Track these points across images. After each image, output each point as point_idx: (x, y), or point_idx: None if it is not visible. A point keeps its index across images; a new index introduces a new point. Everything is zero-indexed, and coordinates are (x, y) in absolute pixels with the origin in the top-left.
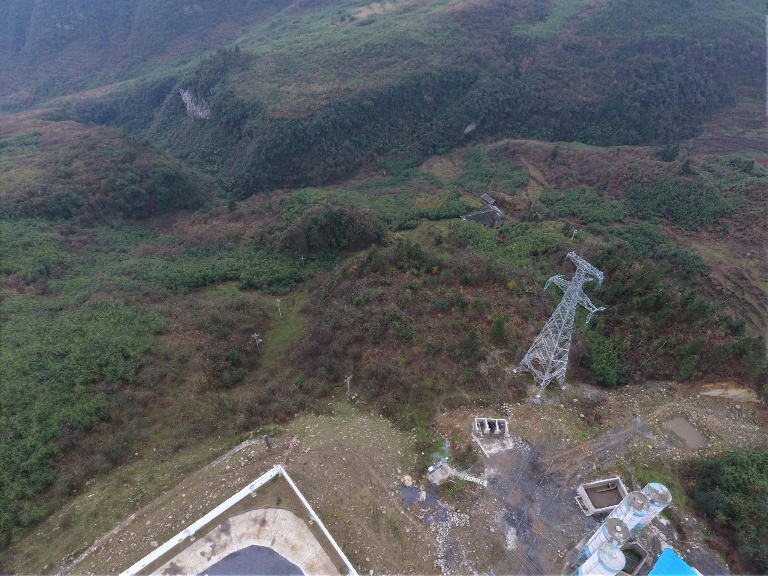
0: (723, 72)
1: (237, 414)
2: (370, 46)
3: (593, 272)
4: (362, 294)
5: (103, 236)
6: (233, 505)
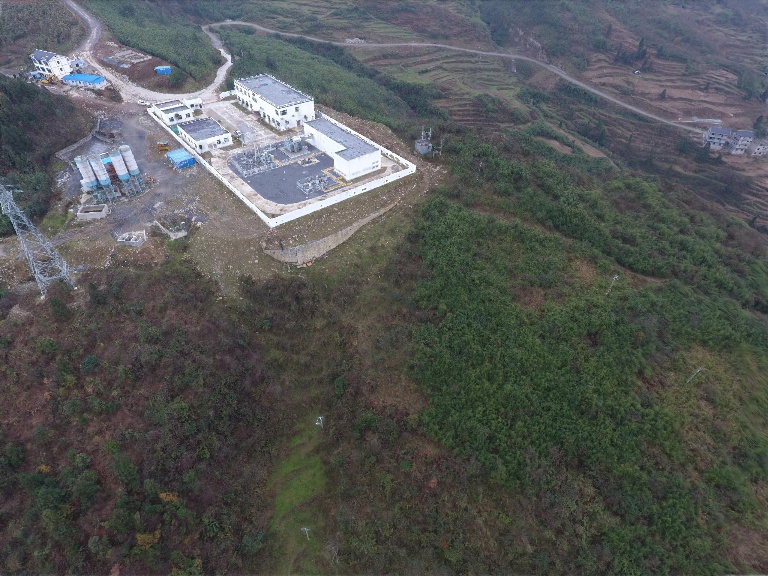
0: None
1: (320, 313)
2: None
3: None
4: (174, 406)
5: None
6: (297, 215)
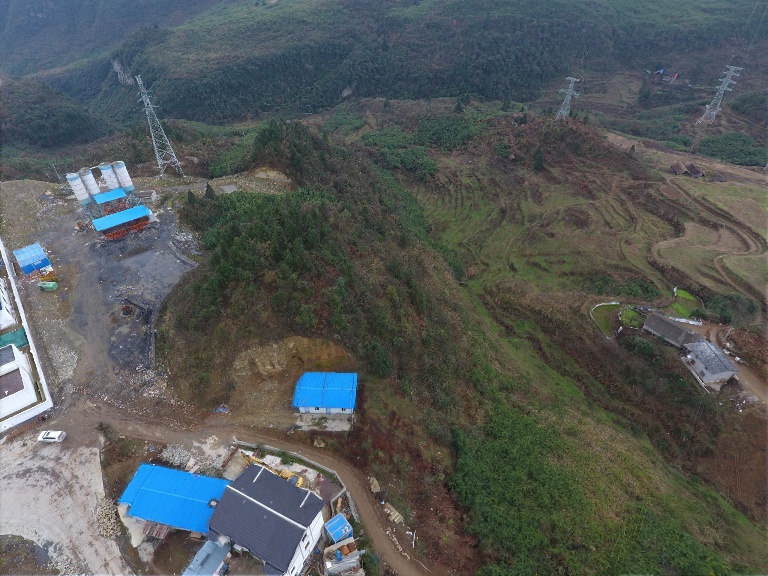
0: (557, 46)
1: None
2: (262, 23)
3: None
4: None
5: (6, 152)
6: None
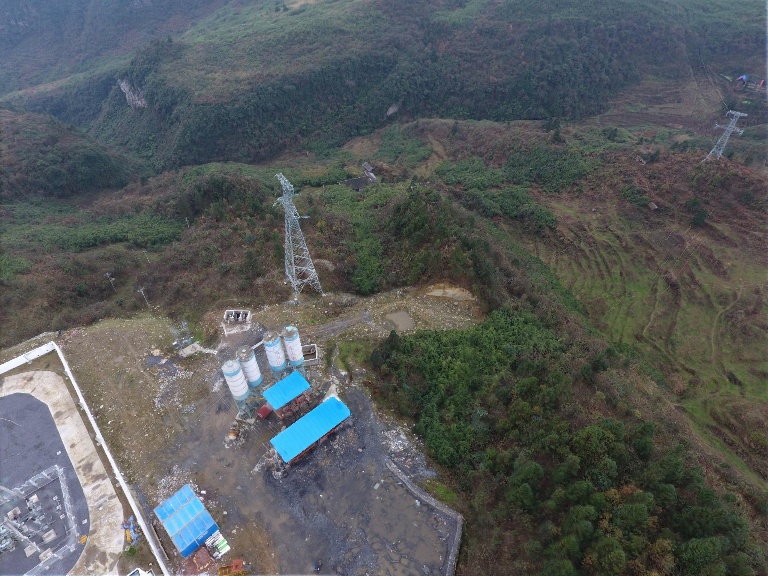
0: (626, 52)
1: None
2: (294, 34)
3: (286, 185)
4: (193, 235)
5: (20, 211)
6: (11, 369)
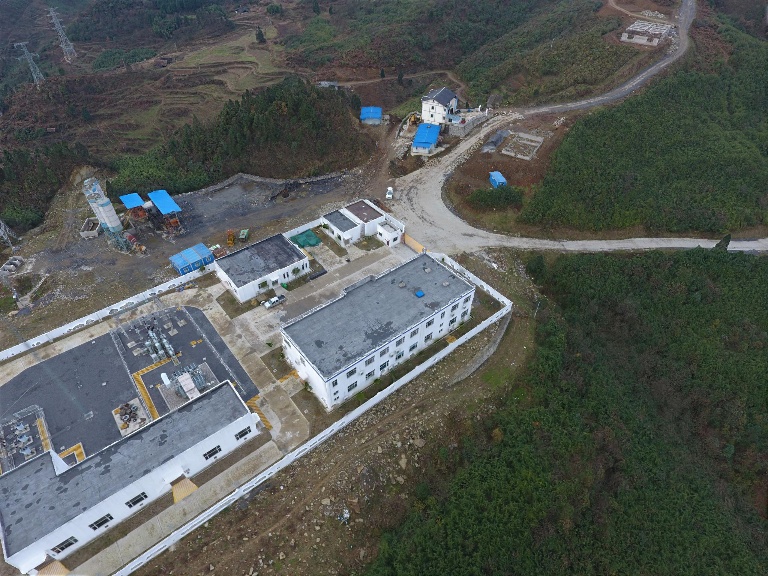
0: None
1: None
2: None
3: None
4: None
5: None
6: None
